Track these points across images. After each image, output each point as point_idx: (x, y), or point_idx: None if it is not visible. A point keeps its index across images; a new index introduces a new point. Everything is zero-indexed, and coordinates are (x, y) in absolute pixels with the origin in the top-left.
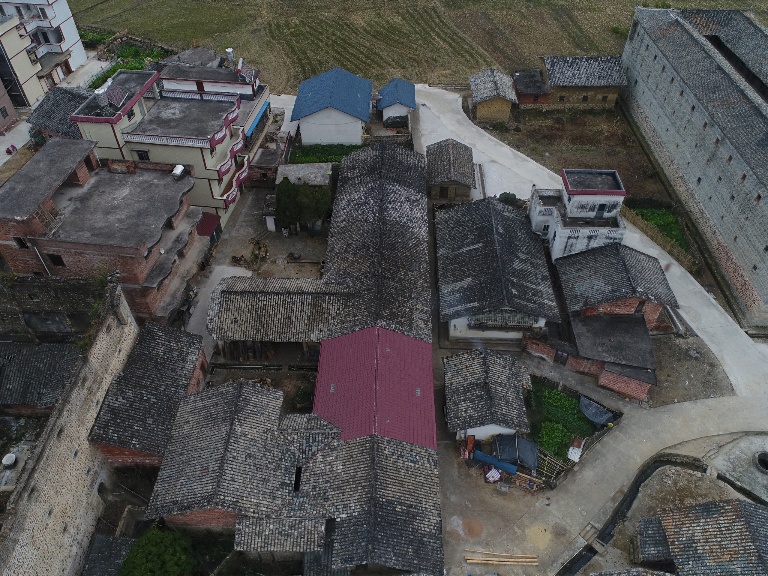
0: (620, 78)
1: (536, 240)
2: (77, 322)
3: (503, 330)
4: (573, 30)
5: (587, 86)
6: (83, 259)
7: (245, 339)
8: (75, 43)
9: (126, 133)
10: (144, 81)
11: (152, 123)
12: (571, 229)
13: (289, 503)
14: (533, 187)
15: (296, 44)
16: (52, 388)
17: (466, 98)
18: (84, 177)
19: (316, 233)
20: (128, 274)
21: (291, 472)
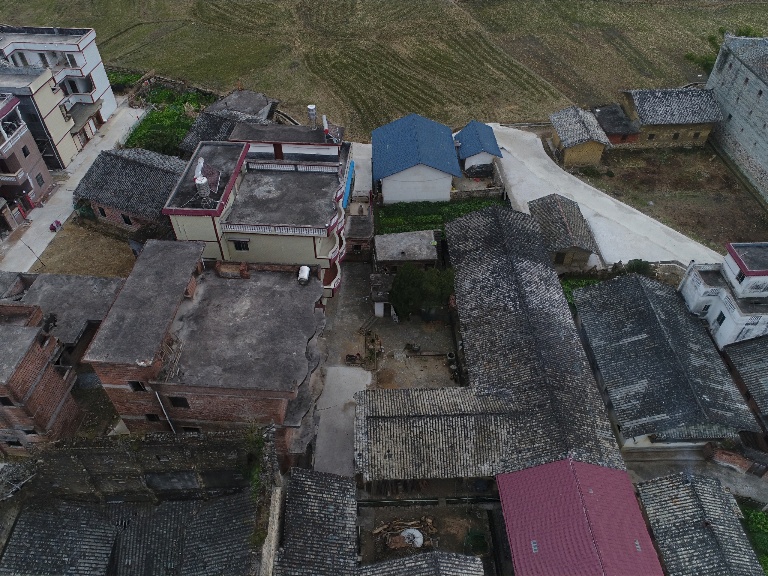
0: (715, 114)
1: (697, 322)
2: (210, 478)
3: (691, 441)
4: (630, 53)
5: (681, 124)
6: (214, 401)
7: (404, 478)
8: (105, 90)
9: (225, 223)
10: (234, 155)
11: (248, 205)
12: (752, 316)
13: None
14: (692, 263)
15: (342, 79)
16: (189, 567)
17: (544, 138)
18: (191, 287)
19: (431, 317)
20: (269, 415)
21: None
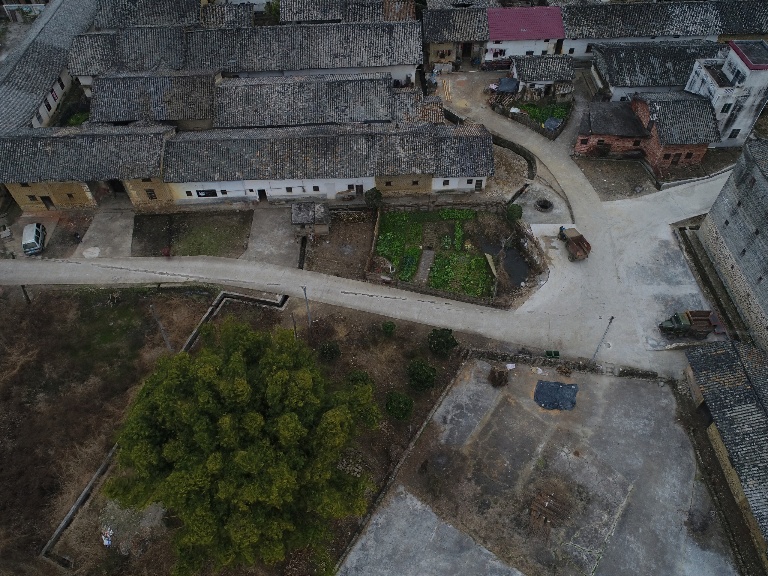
0: None
1: None
2: None
3: None
4: None
5: None
6: None
7: None
8: None
9: None
10: None
11: None
12: None
13: (449, 3)
14: None
15: None
16: None
17: None
18: None
19: None
20: None
21: (464, 1)
